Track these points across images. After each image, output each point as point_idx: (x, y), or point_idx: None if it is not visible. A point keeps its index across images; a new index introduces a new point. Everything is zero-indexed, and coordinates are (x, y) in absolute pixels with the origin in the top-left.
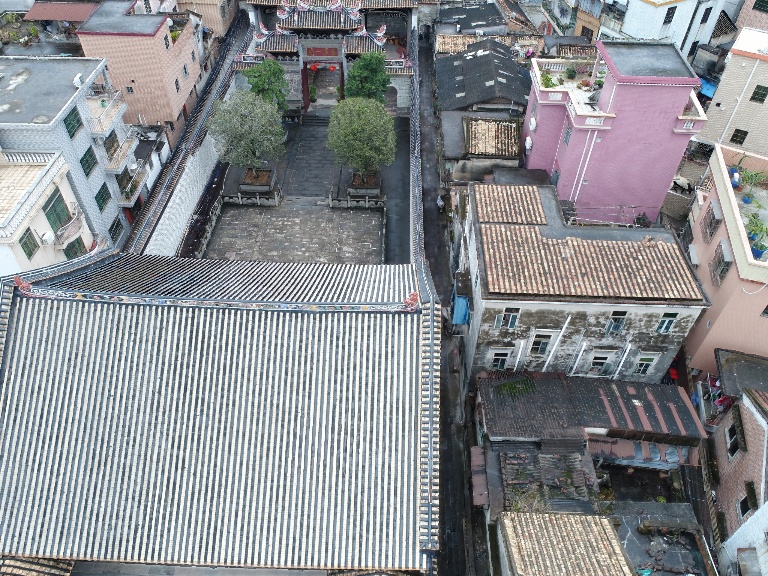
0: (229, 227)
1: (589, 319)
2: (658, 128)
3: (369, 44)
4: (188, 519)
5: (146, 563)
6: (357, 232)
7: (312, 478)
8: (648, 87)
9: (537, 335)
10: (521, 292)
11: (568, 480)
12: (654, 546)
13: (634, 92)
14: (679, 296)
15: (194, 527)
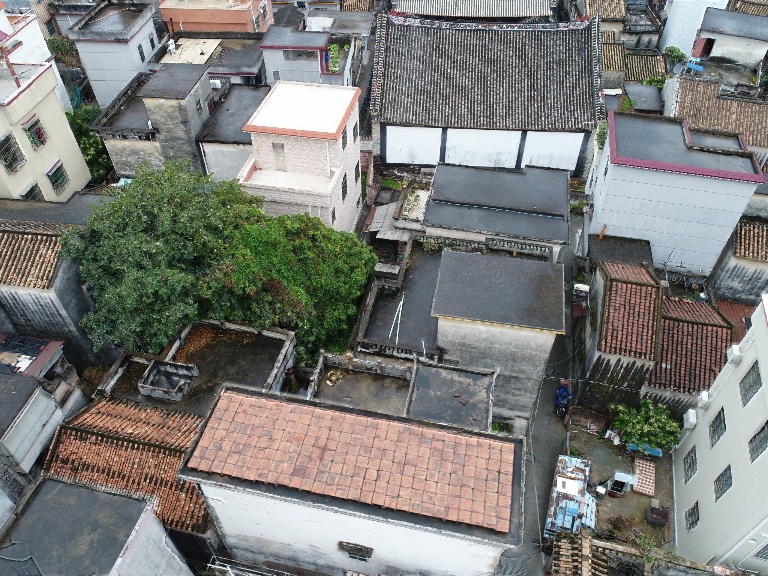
0: None
1: None
2: None
3: None
4: (469, 4)
5: (455, 16)
6: None
7: None
8: None
9: None
10: None
11: None
12: None
13: None
14: None
15: (471, 6)
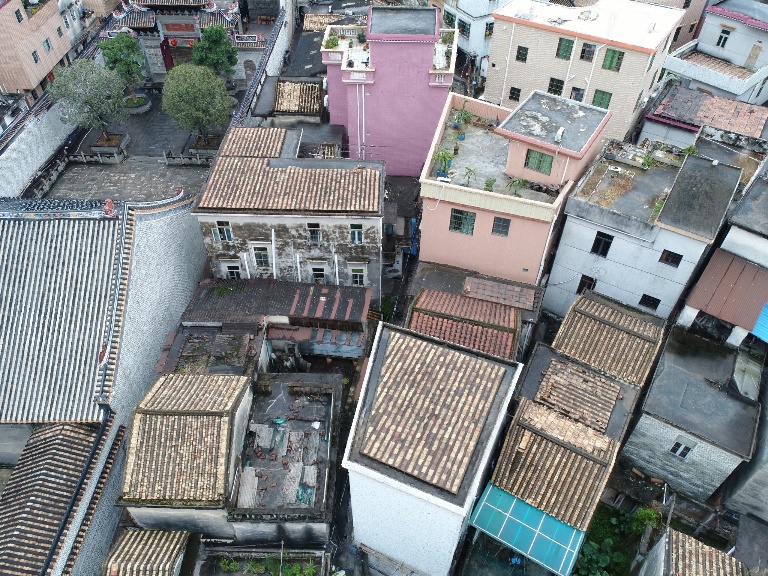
0: (69, 181)
1: (291, 231)
2: (416, 82)
3: (220, 20)
4: None
5: None
6: (184, 185)
7: (19, 352)
8: (396, 44)
9: (255, 248)
10: (225, 207)
11: (234, 353)
12: (297, 403)
13: (385, 49)
14: (358, 209)
15: None
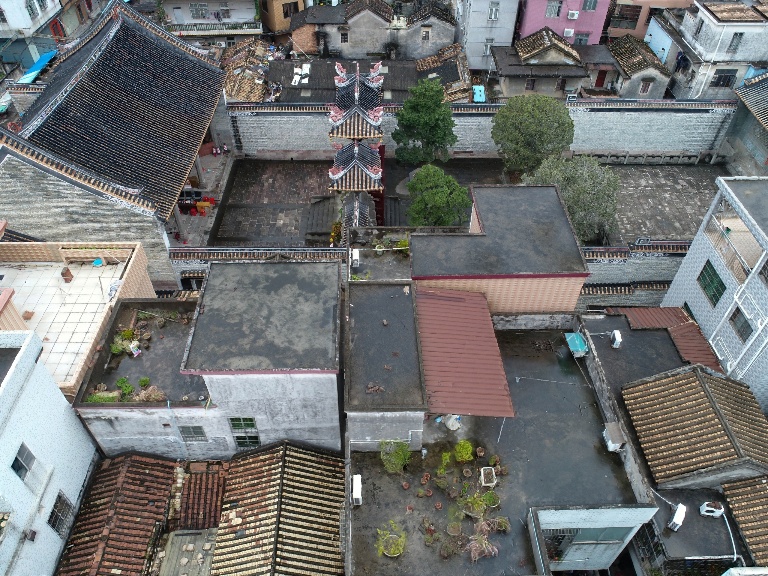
0: None
1: None
2: None
3: None
4: None
5: None
6: None
7: None
8: None
9: None
10: None
11: None
12: None
13: None
14: None
15: None
